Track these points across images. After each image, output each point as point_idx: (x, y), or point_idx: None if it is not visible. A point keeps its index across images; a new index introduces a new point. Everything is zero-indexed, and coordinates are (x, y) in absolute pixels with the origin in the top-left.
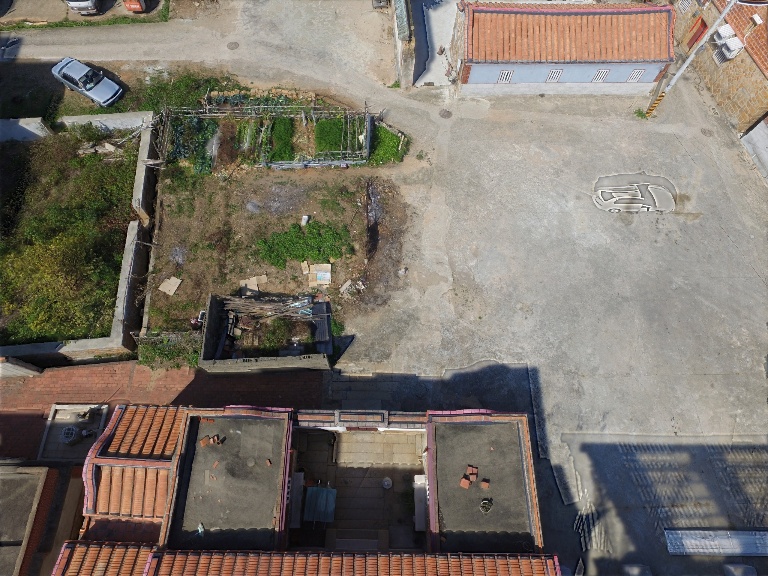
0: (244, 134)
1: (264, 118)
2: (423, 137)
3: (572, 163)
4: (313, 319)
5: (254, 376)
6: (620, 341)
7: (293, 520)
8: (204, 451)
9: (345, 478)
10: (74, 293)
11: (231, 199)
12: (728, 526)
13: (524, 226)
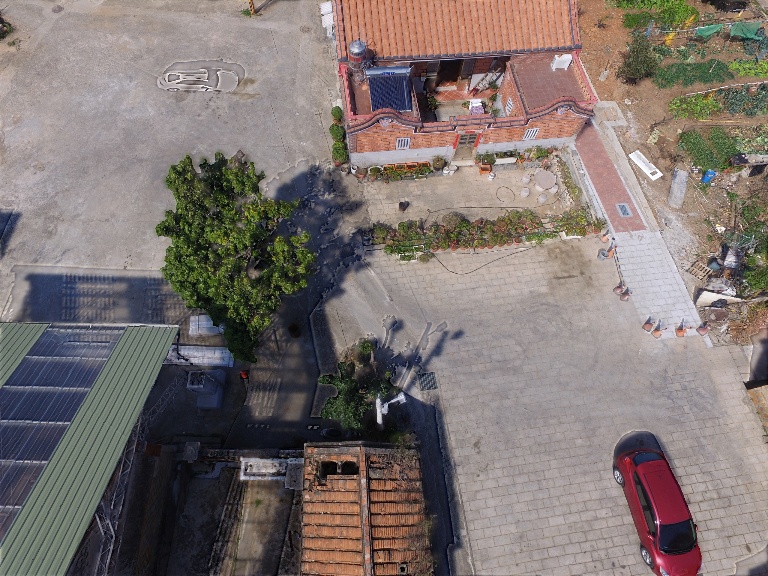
0: None
1: None
2: (26, 28)
3: (155, 51)
4: None
5: None
6: (115, 193)
7: None
8: None
9: None
10: None
11: None
12: None
13: (77, 100)
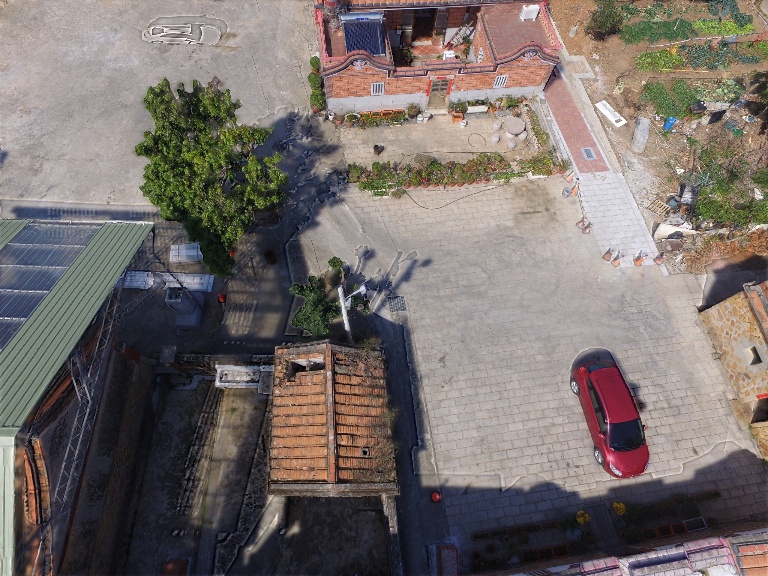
0: None
1: None
2: None
3: (140, 6)
4: None
5: None
6: (99, 136)
7: None
8: None
9: None
10: None
11: None
12: None
13: (63, 51)
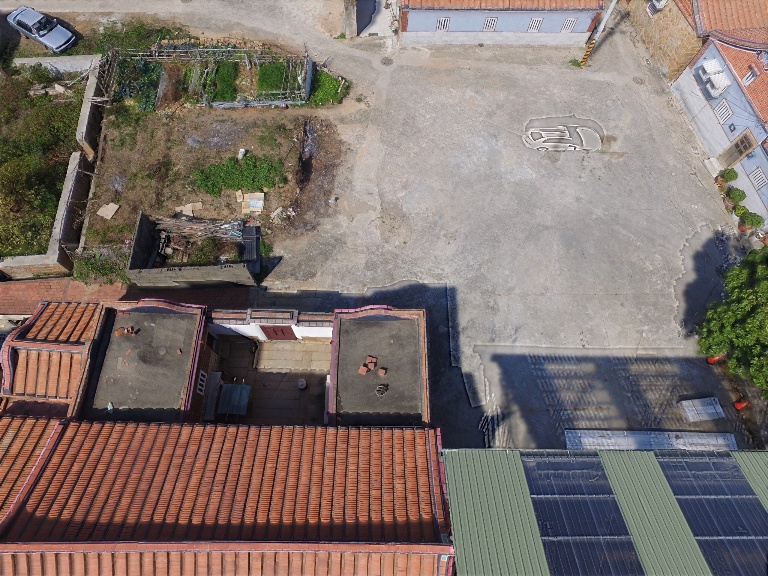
0: (189, 77)
1: (209, 62)
2: (364, 82)
3: (505, 106)
4: (242, 240)
5: (183, 291)
6: (537, 264)
7: (208, 413)
8: (118, 340)
9: (264, 382)
10: (14, 215)
11: (172, 134)
12: (626, 427)
13: (454, 162)
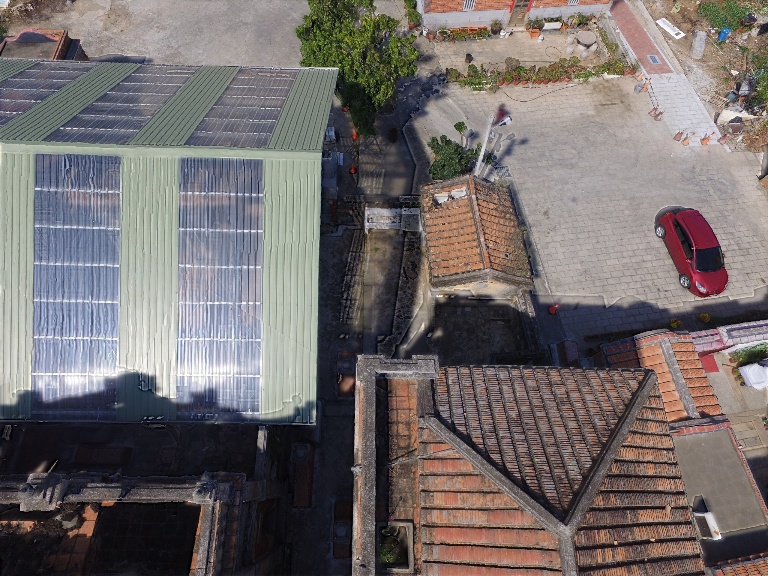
0: None
1: None
2: None
3: None
4: None
5: None
6: (228, 47)
7: None
8: None
9: None
10: None
11: None
12: None
13: None
